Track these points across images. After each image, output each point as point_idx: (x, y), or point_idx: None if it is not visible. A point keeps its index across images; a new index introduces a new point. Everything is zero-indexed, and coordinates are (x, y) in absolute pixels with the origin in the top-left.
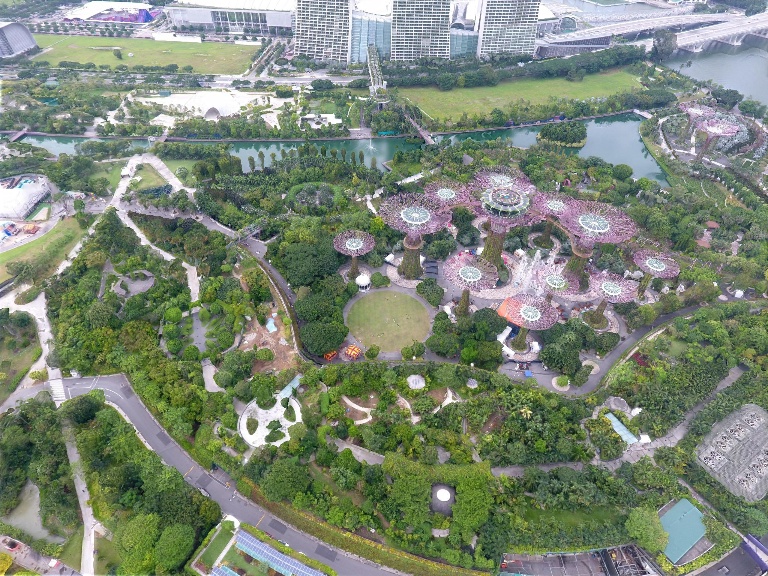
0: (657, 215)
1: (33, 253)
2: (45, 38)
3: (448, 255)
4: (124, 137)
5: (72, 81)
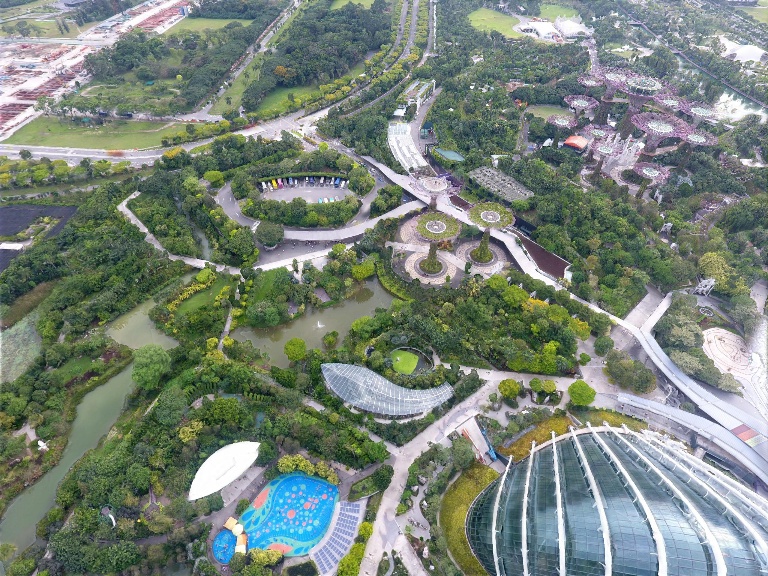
0: None
1: (542, 42)
2: None
3: None
4: None
5: (712, 16)
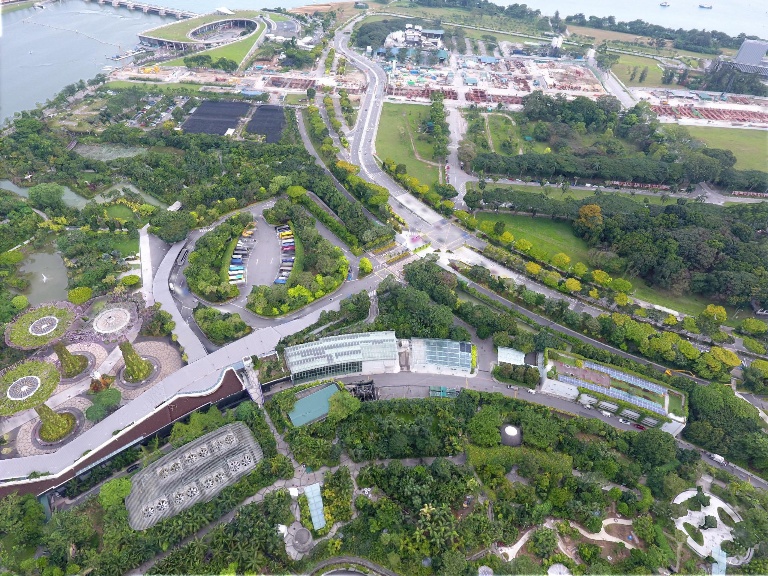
0: None
1: None
2: None
3: None
4: None
5: None
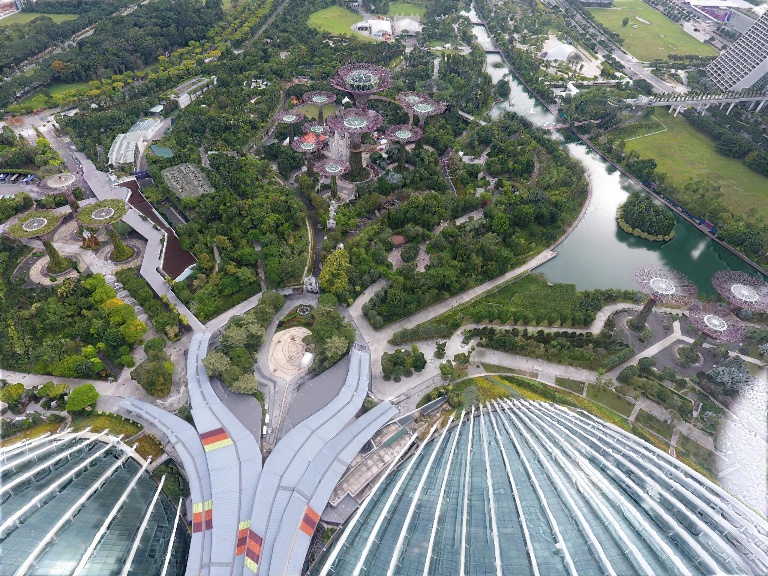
0: (416, 195)
1: None
2: (638, 4)
3: (379, 132)
4: (495, 43)
5: (553, 16)
